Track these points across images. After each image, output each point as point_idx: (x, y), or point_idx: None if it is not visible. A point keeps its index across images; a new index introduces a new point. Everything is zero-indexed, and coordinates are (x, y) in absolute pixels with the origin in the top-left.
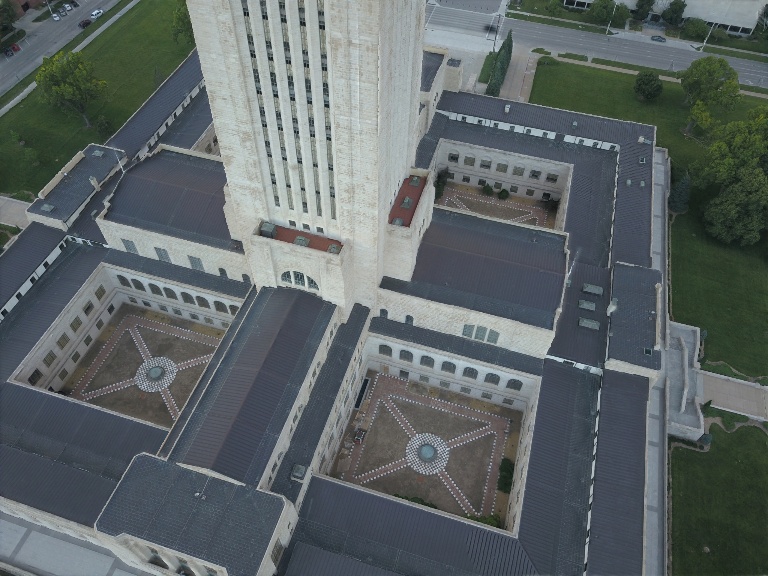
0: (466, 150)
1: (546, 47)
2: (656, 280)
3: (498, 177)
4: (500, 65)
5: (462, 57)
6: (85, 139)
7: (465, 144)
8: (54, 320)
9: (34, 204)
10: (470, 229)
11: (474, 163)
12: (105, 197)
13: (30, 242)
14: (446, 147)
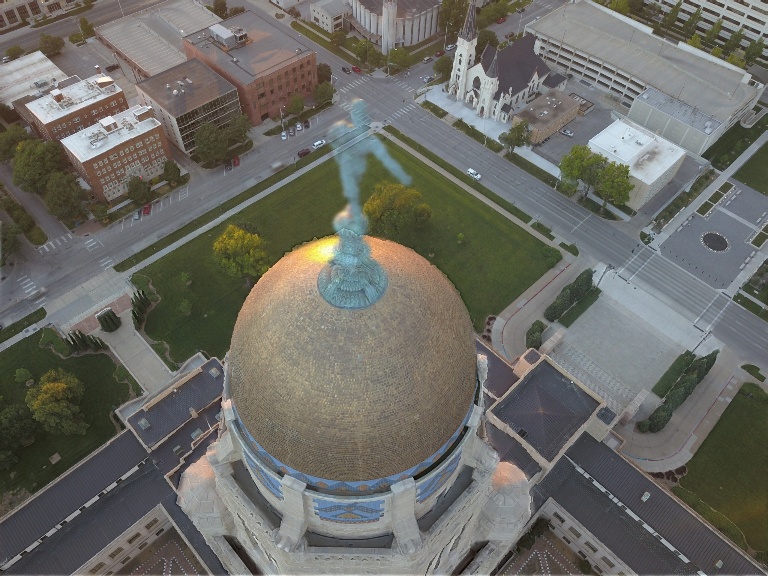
0: (574, 524)
1: (763, 367)
2: None
3: (601, 564)
4: (683, 392)
5: (650, 345)
6: (238, 300)
7: (574, 520)
8: (93, 556)
9: (137, 413)
10: None
11: (579, 537)
12: (196, 429)
13: (117, 452)
14: (554, 507)
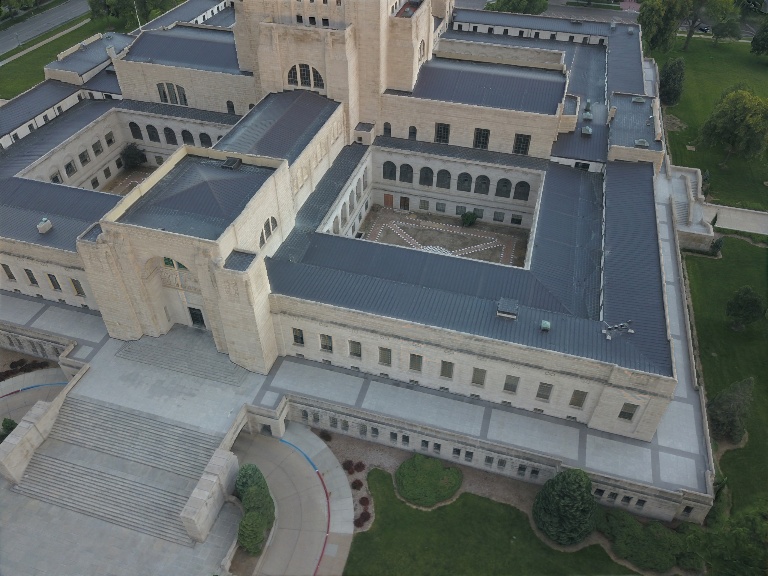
0: None
1: None
2: (55, 64)
3: None
4: None
5: None
6: None
7: None
8: None
9: None
10: (205, 66)
11: None
12: None
13: None
14: None
